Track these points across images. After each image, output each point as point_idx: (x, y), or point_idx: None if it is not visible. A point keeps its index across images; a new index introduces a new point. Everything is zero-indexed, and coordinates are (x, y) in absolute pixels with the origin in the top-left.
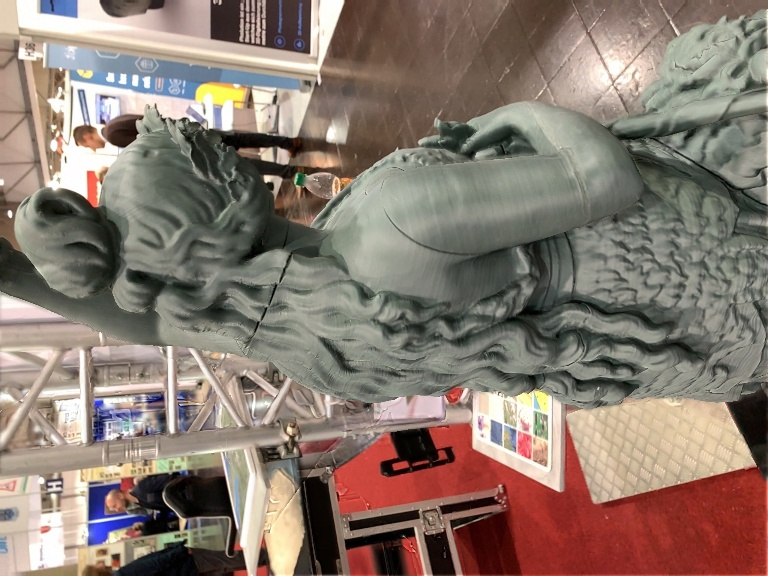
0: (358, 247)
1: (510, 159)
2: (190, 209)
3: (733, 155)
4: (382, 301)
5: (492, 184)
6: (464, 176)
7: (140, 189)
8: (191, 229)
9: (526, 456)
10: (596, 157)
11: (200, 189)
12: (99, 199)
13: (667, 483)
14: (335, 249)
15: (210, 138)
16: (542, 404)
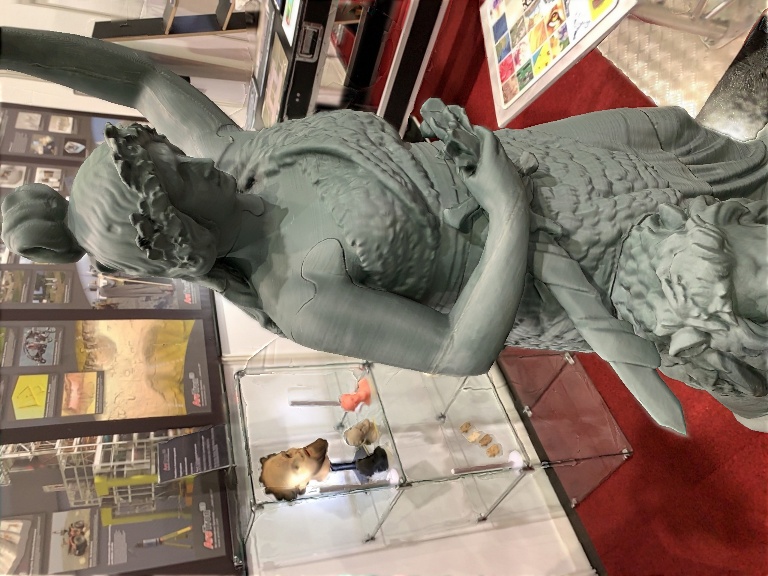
0: (271, 314)
1: (409, 327)
2: (146, 267)
3: None
4: (278, 333)
5: (374, 351)
6: (358, 338)
7: (105, 252)
8: (146, 275)
9: (501, 77)
10: (459, 366)
11: (156, 261)
12: (70, 219)
13: (638, 84)
14: (260, 293)
15: (170, 230)
16: (538, 65)
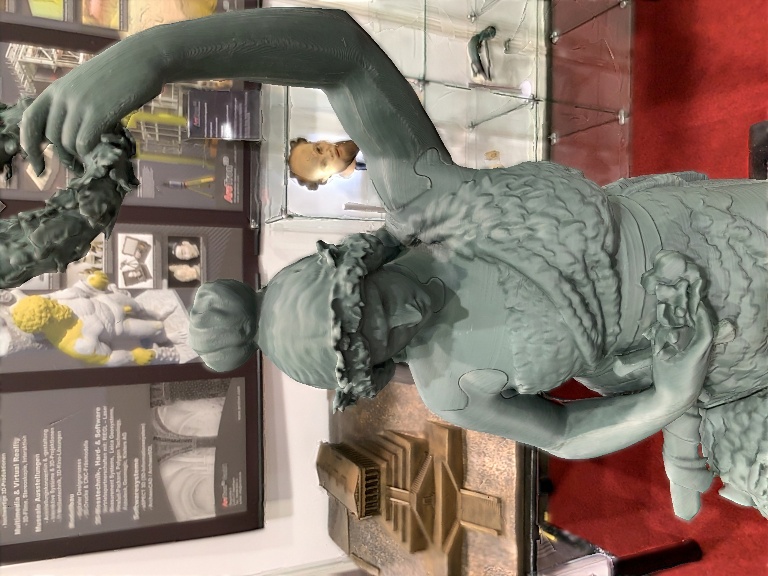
0: (414, 378)
1: None
2: None
3: (704, 429)
4: None
5: None
6: None
7: None
8: None
9: None
10: None
11: None
12: (262, 343)
13: None
14: (410, 361)
15: None
16: None
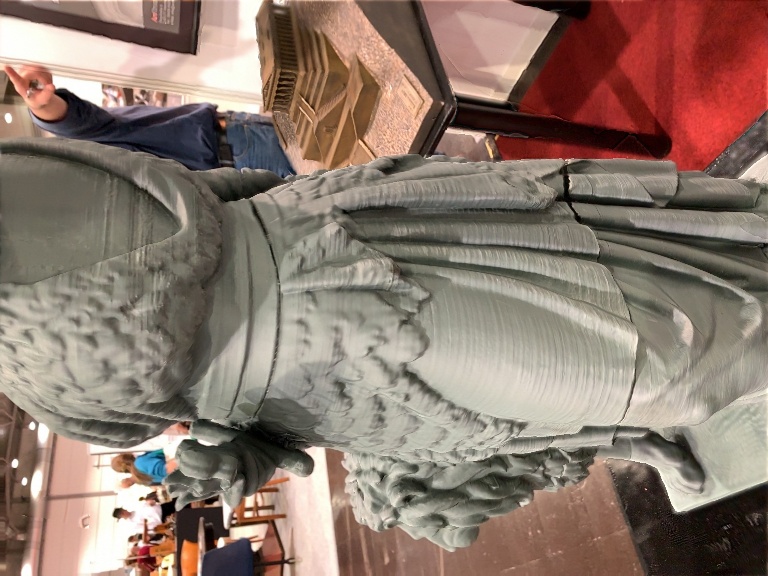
0: None
1: None
2: None
3: None
4: None
5: None
6: None
7: None
8: None
9: None
10: None
11: None
12: None
13: None
14: None
15: None
16: None
